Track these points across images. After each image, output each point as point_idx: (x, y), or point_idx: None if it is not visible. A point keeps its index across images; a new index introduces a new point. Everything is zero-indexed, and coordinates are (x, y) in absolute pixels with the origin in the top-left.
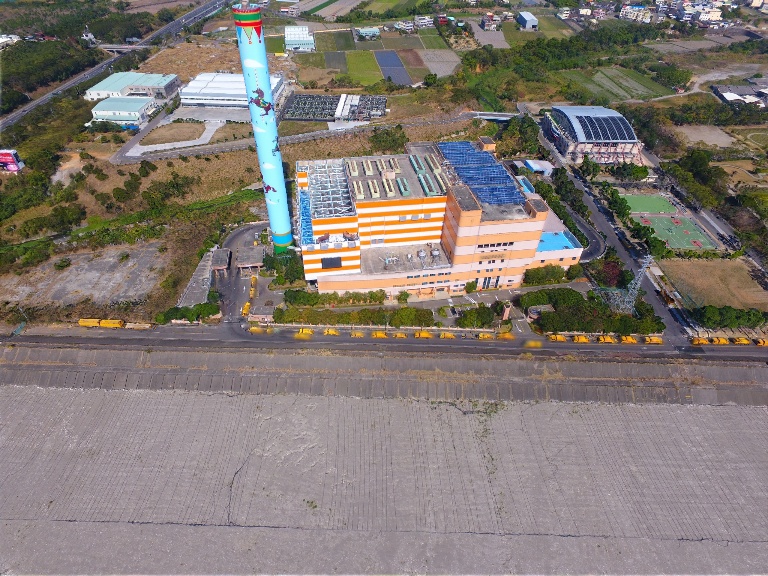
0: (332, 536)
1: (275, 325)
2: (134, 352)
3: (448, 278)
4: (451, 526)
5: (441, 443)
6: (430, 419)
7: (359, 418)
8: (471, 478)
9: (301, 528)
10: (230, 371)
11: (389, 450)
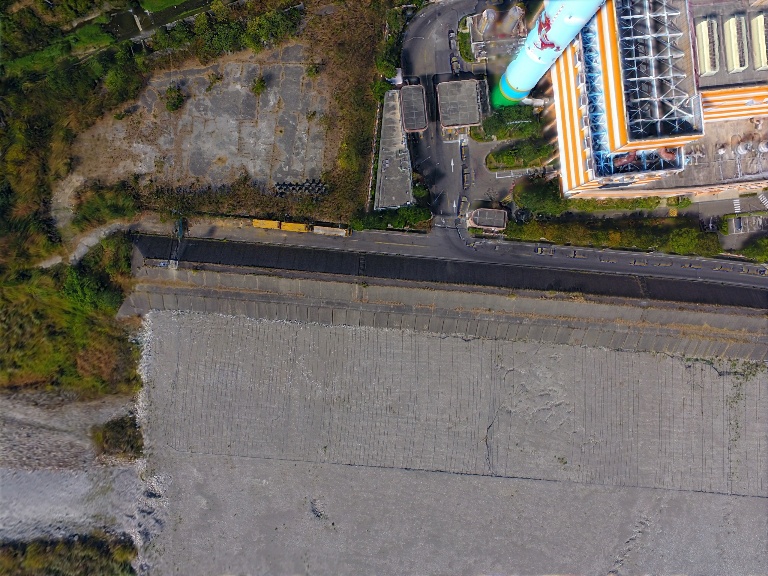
0: (582, 488)
1: (503, 235)
2: (346, 285)
3: (759, 184)
4: (686, 486)
5: (690, 407)
6: (683, 380)
7: (607, 374)
8: (713, 445)
9: (555, 481)
10: (463, 312)
11: (636, 412)
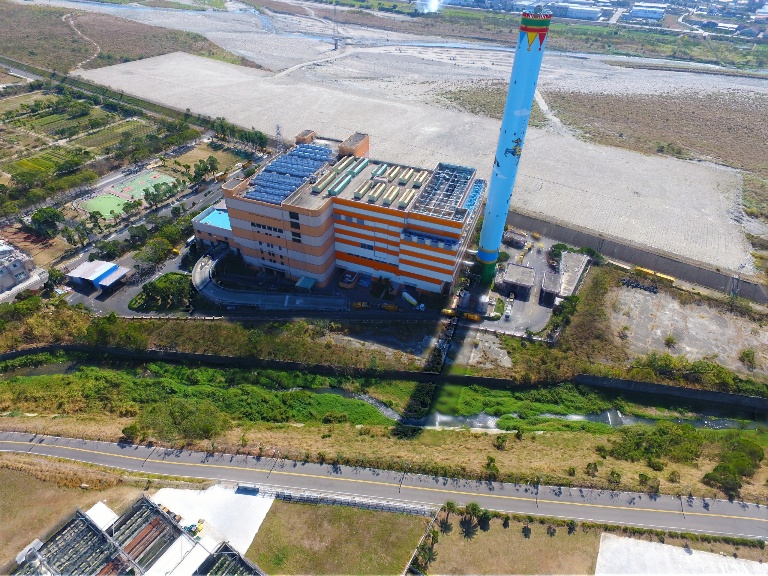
0: None
1: None
2: None
3: None
4: None
5: None
6: None
7: None
8: None
9: None
10: None
11: None
